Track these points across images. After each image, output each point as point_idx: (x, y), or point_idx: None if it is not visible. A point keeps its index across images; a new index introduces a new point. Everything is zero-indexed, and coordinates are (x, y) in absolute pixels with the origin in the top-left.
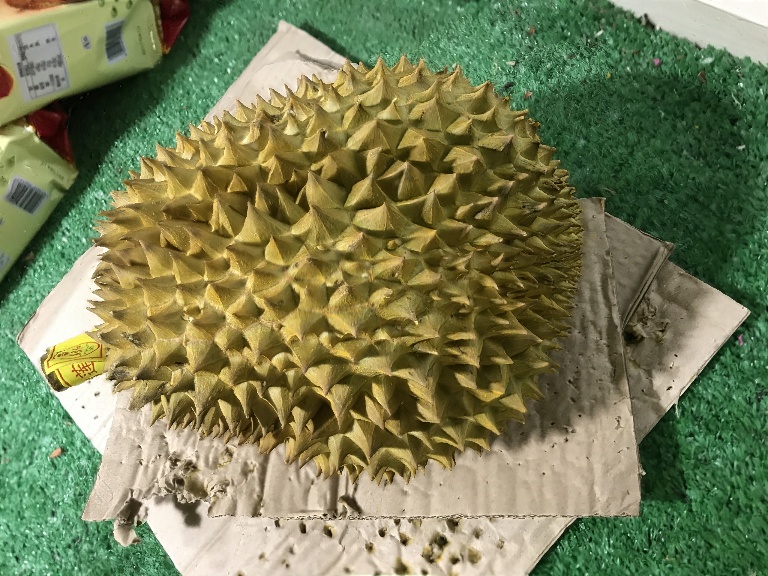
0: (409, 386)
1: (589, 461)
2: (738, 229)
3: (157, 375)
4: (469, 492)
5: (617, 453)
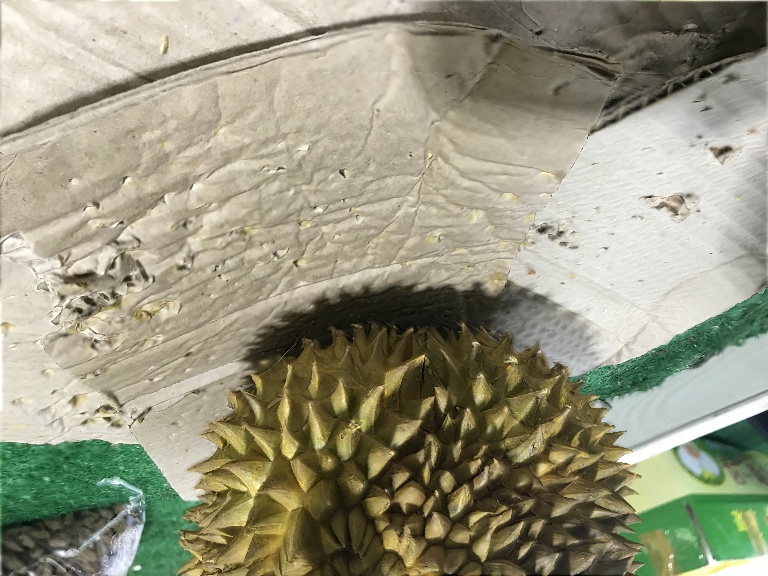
0: None
1: None
2: None
3: None
4: None
5: None
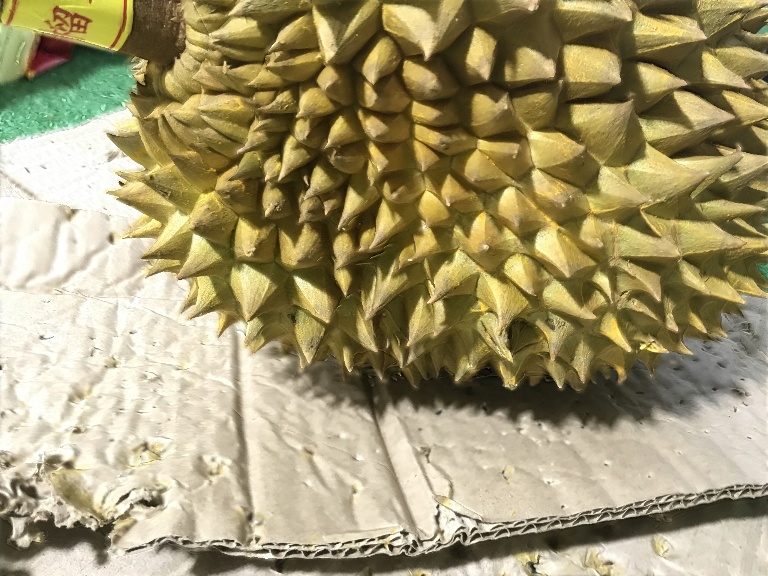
0: (726, 98)
1: None
2: None
3: None
4: (661, 466)
5: None
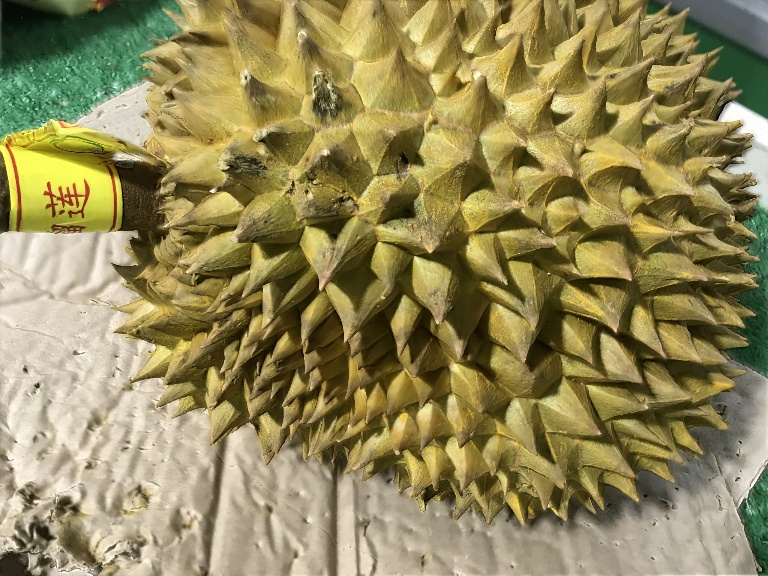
0: (659, 333)
1: (704, 545)
2: (758, 333)
3: (351, 170)
4: None
5: (731, 539)
